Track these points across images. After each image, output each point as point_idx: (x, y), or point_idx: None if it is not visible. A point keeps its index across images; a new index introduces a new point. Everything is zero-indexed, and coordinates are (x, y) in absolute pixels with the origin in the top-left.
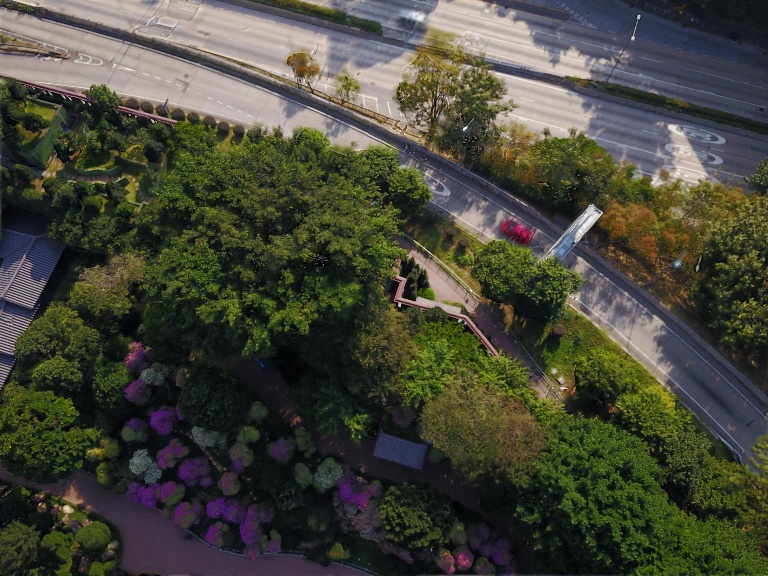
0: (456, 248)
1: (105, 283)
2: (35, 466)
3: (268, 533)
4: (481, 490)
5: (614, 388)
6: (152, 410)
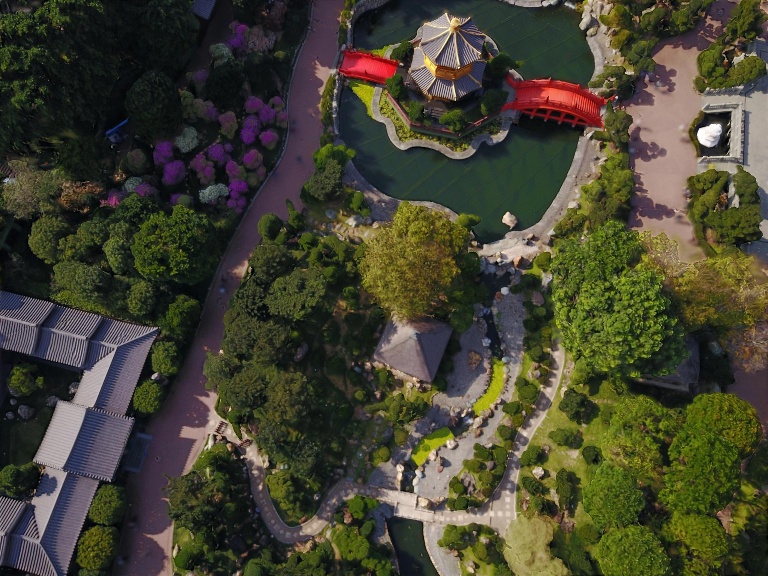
0: None
1: (30, 183)
2: (200, 233)
3: None
4: None
5: None
6: None
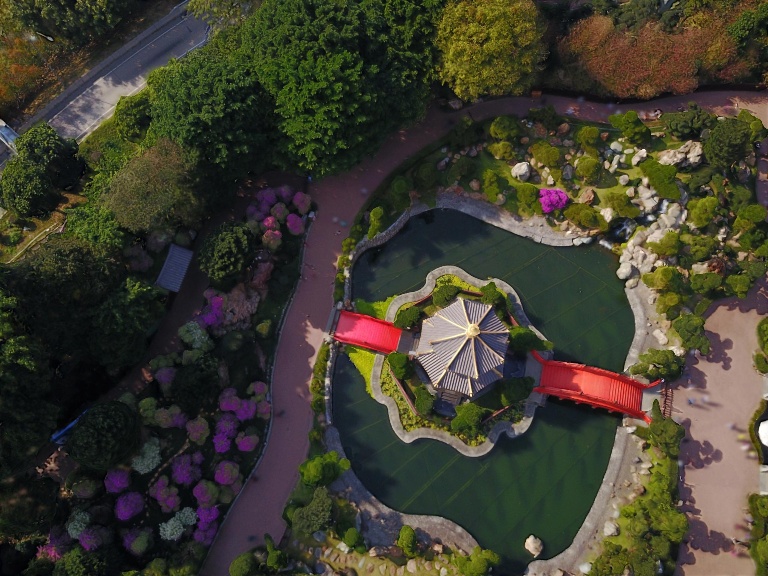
0: (1, 244)
1: None
2: None
3: (249, 396)
4: (209, 200)
5: (142, 105)
6: (123, 532)
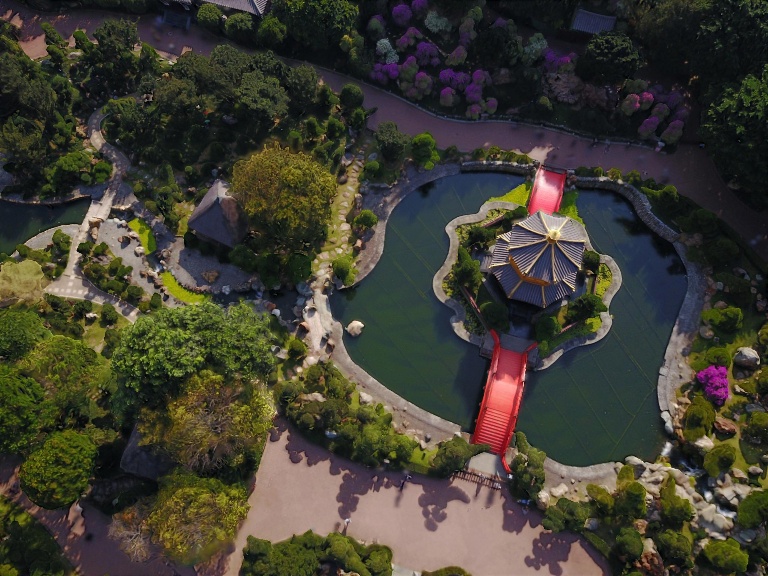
0: None
1: None
2: (322, 18)
3: (485, 99)
4: (663, 38)
5: None
6: None
